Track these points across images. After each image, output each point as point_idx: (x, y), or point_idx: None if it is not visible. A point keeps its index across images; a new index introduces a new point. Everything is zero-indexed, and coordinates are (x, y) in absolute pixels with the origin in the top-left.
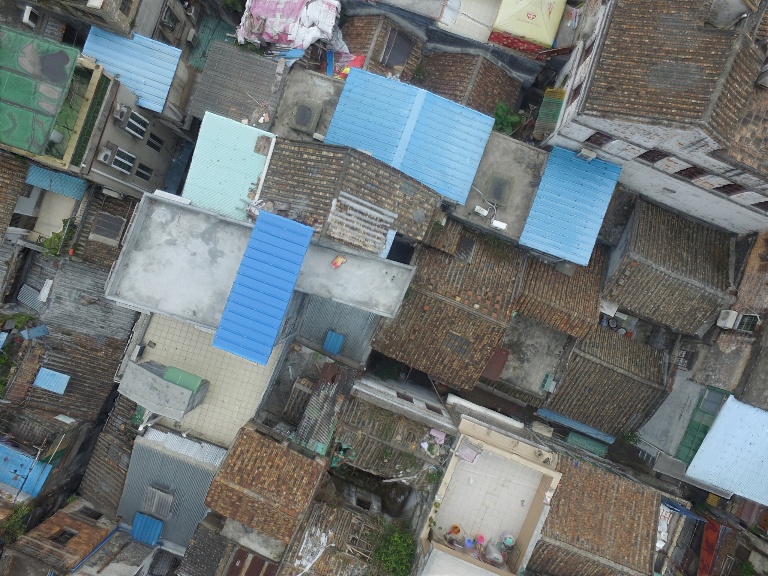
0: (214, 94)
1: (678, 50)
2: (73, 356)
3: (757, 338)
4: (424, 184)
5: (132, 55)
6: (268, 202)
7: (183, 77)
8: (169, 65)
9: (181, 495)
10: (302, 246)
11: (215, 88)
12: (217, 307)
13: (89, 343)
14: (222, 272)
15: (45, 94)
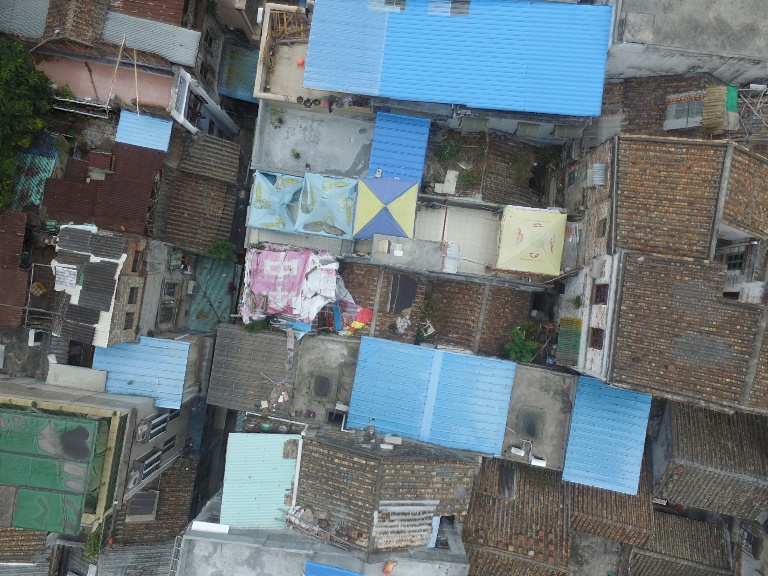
0: (229, 379)
1: (700, 321)
2: None
3: None
4: (457, 444)
5: (141, 358)
6: (306, 510)
7: (193, 356)
8: (179, 360)
9: None
10: None
11: (229, 373)
12: None
13: None
14: None
15: (70, 473)
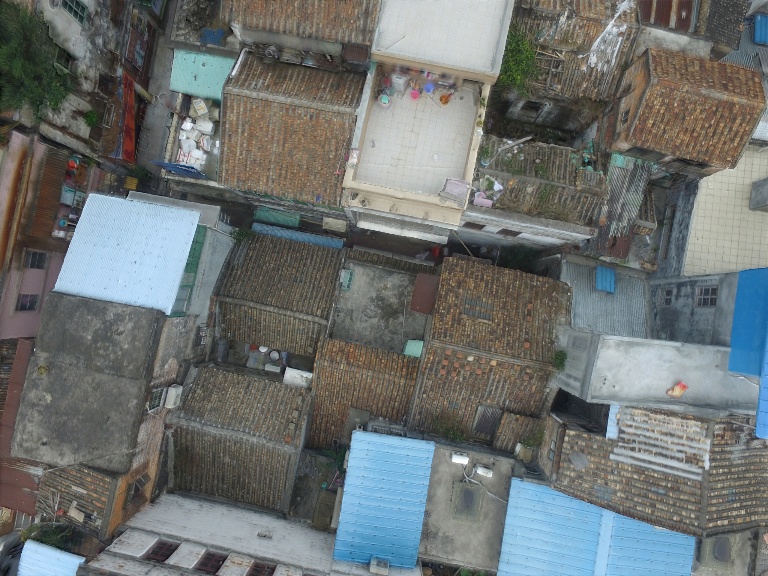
0: None
1: None
2: None
3: (149, 387)
4: None
5: None
6: None
7: None
8: None
9: None
10: (767, 412)
11: None
12: None
13: None
14: None
15: None
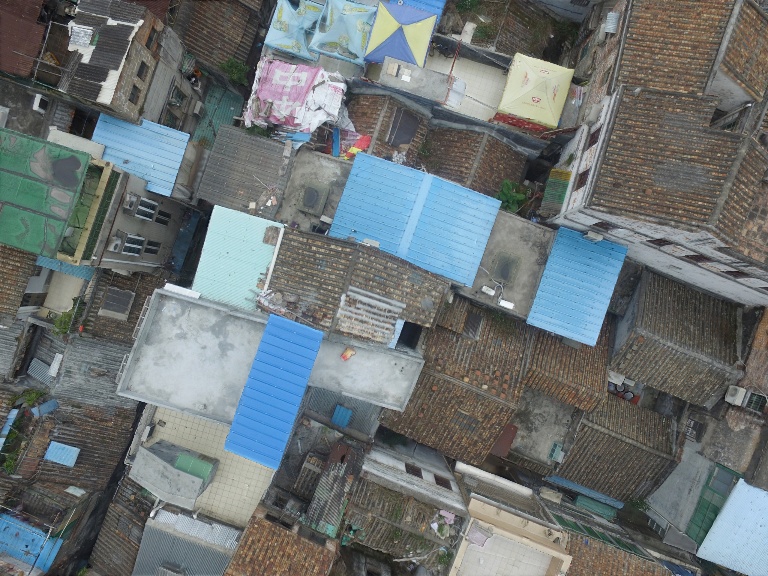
0: (222, 177)
1: (684, 149)
2: (83, 428)
3: (766, 421)
4: (431, 267)
5: (141, 140)
6: (277, 293)
7: (191, 157)
8: (177, 149)
9: (192, 573)
10: (312, 350)
11: (223, 171)
12: (228, 400)
13: (99, 414)
14: (232, 365)
15: (57, 198)
